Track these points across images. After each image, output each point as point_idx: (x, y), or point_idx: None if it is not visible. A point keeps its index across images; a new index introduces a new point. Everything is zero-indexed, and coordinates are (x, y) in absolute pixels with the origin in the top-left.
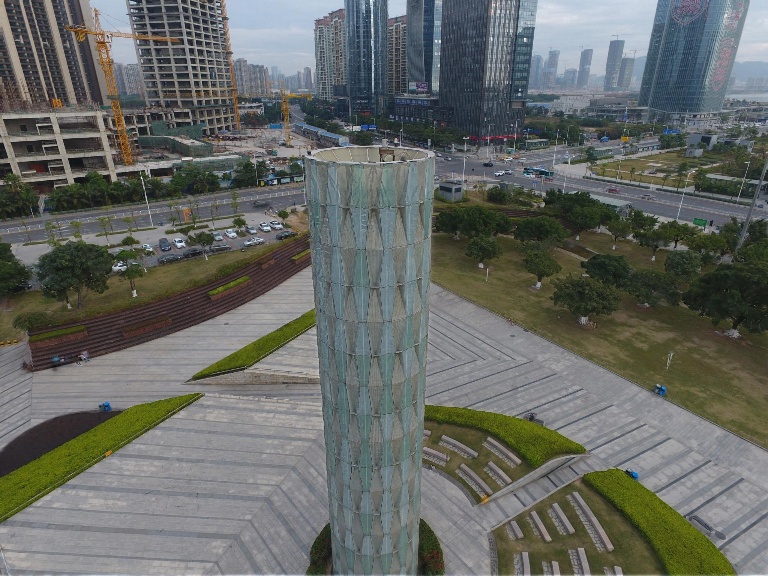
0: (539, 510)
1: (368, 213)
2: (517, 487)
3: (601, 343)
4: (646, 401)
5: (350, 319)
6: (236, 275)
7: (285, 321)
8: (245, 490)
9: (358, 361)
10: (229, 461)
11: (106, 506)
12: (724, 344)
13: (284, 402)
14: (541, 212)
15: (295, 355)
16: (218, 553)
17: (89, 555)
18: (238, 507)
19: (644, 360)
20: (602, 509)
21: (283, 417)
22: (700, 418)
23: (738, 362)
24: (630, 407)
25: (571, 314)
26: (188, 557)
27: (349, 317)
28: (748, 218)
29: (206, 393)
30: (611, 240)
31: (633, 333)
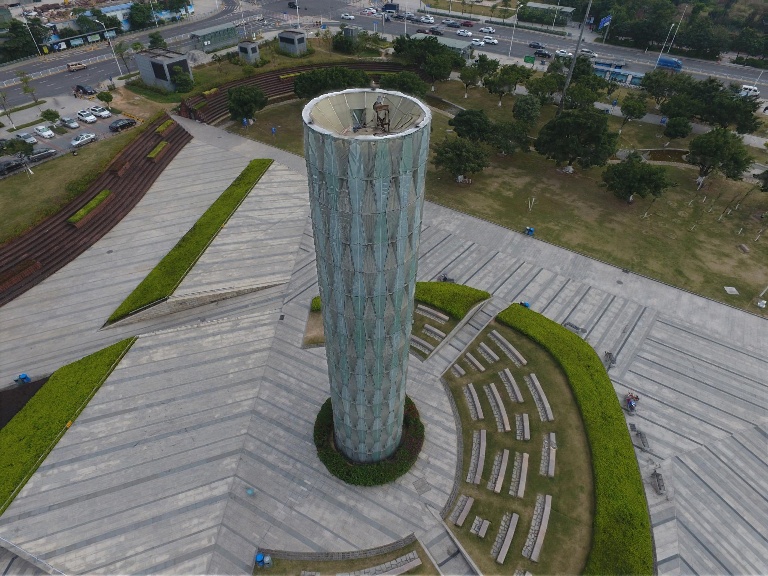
0: (471, 351)
1: (390, 182)
2: (450, 338)
3: (478, 198)
4: (521, 242)
5: (369, 270)
6: (92, 191)
7: (178, 234)
8: (229, 411)
9: (375, 301)
10: (200, 391)
11: (100, 470)
12: (564, 180)
13: (224, 321)
14: (394, 63)
15: (212, 271)
16: (233, 468)
17: (112, 515)
18: (230, 426)
19: (513, 207)
20: (513, 337)
21: (231, 336)
22: (558, 247)
23: (575, 194)
24: (511, 250)
25: (448, 174)
26: (208, 481)
27: (367, 269)
28: (574, 60)
29: (139, 335)
30: (461, 87)
31: (500, 183)
